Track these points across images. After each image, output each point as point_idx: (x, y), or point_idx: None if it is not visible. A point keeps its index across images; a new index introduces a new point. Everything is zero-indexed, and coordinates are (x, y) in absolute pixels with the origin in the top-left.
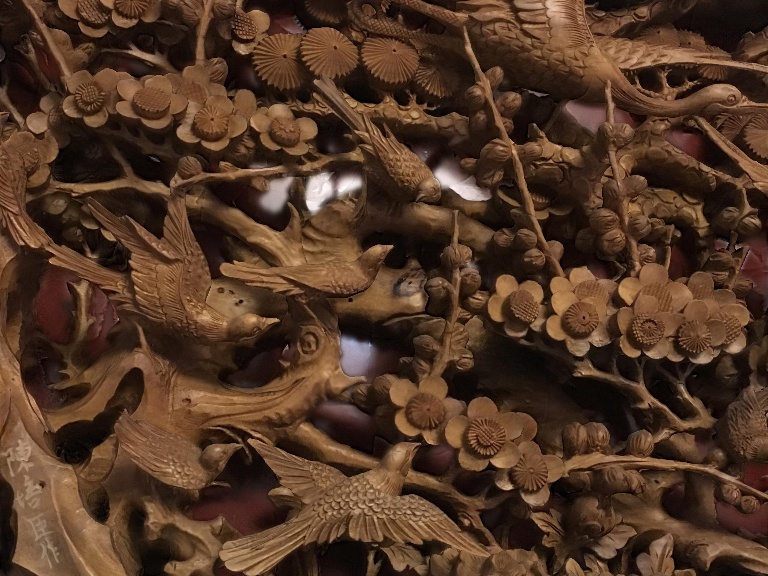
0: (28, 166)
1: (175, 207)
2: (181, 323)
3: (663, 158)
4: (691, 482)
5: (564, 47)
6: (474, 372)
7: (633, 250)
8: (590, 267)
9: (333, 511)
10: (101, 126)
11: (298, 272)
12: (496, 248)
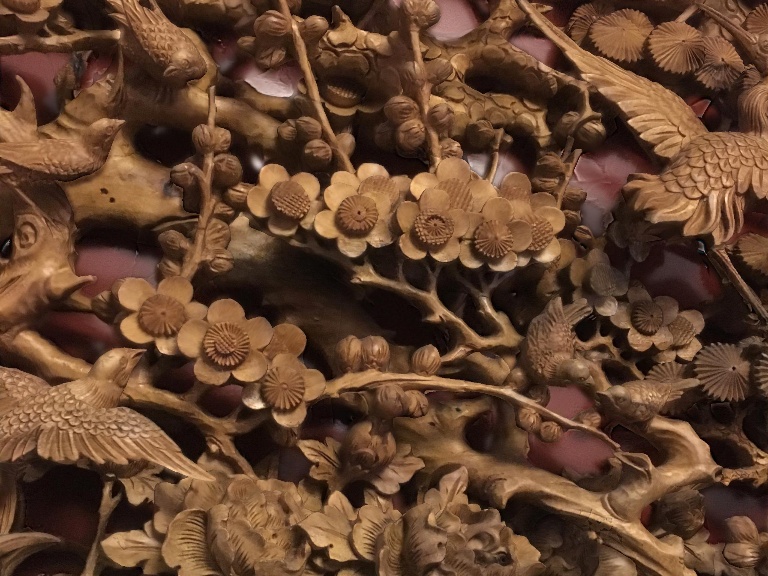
0: None
1: None
2: None
3: (500, 57)
4: (502, 412)
5: None
6: (258, 286)
7: (433, 143)
8: None
9: (20, 424)
10: None
11: (5, 148)
12: (282, 143)
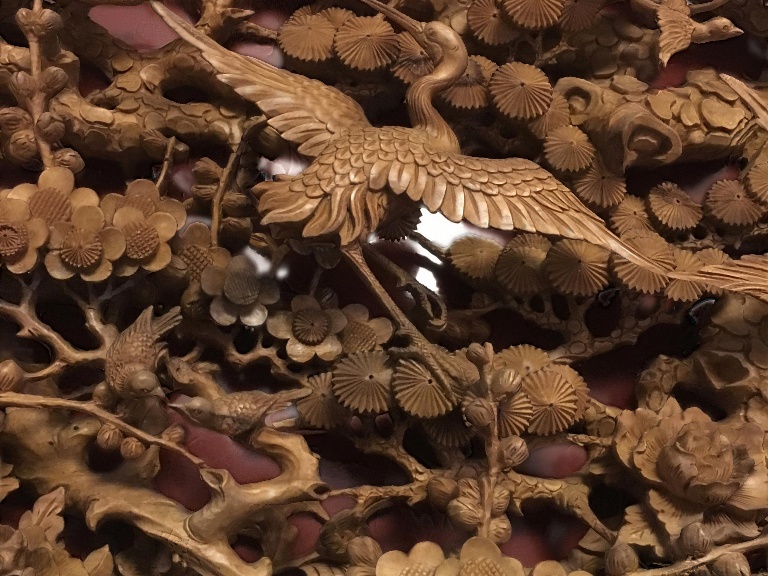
0: None
1: None
2: None
3: (189, 65)
4: None
5: None
6: None
7: (43, 153)
8: None
9: None
10: None
11: None
12: None
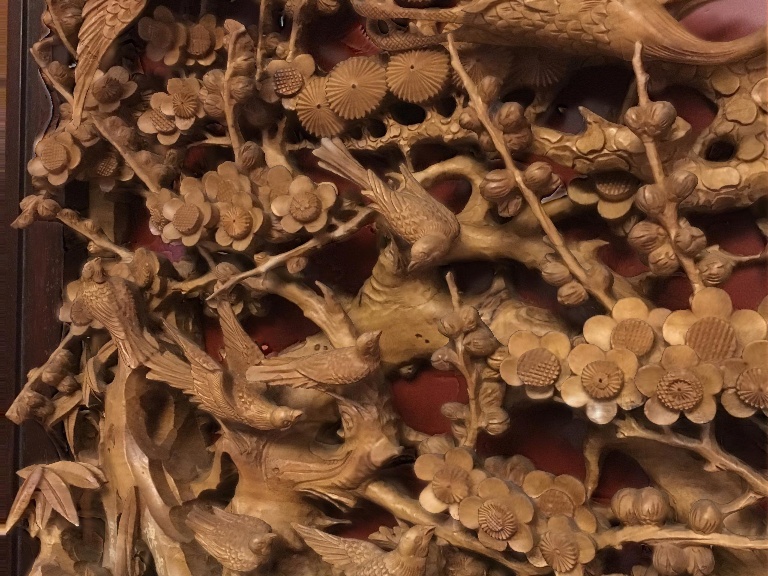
0: (145, 280)
1: (223, 310)
2: (237, 419)
3: None
4: None
5: (577, 12)
6: None
7: (688, 270)
8: (726, 242)
9: None
10: (171, 241)
11: (308, 366)
12: None
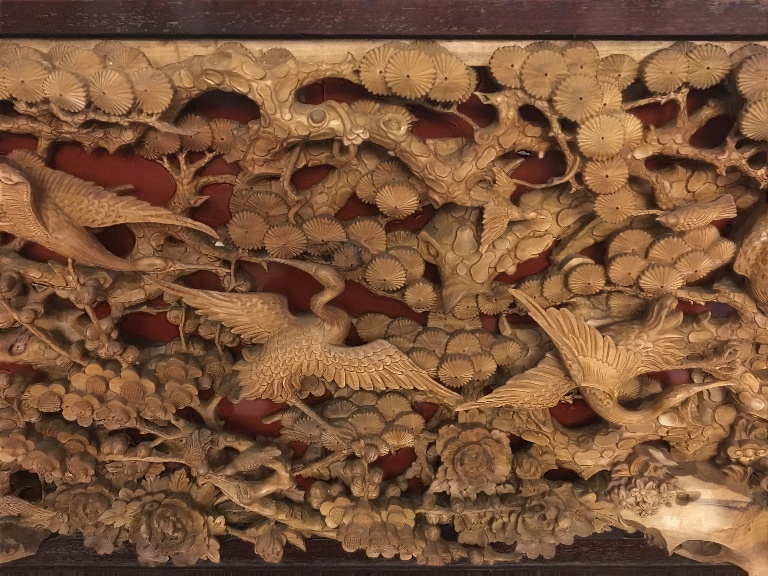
0: None
1: None
2: None
3: None
4: None
5: (31, 236)
6: None
7: None
8: (150, 303)
9: None
10: None
11: None
12: None
